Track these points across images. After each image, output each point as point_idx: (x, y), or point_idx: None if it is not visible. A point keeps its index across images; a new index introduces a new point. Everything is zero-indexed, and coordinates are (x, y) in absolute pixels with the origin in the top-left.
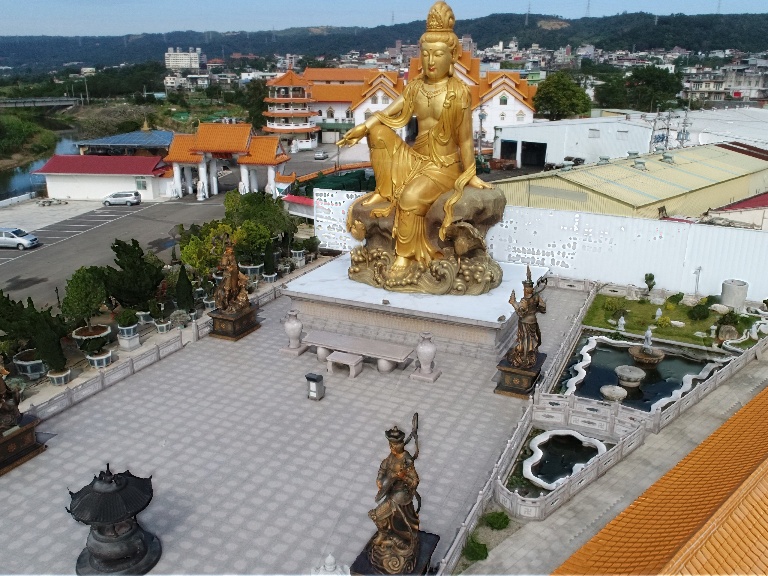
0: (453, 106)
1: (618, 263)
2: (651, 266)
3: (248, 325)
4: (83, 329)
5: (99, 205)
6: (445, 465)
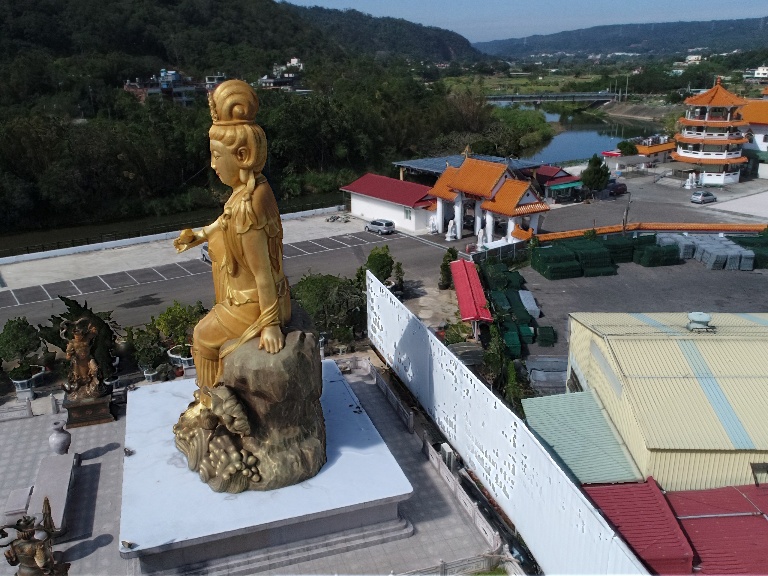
0: (231, 228)
1: (545, 534)
2: (572, 572)
3: (95, 416)
4: None
5: (362, 229)
6: None
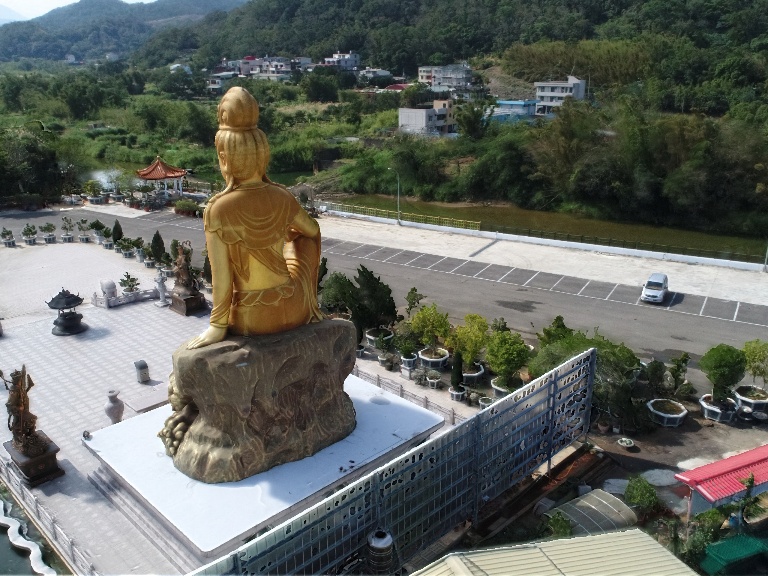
0: None
1: None
2: None
3: None
4: (346, 315)
5: None
6: (4, 407)
